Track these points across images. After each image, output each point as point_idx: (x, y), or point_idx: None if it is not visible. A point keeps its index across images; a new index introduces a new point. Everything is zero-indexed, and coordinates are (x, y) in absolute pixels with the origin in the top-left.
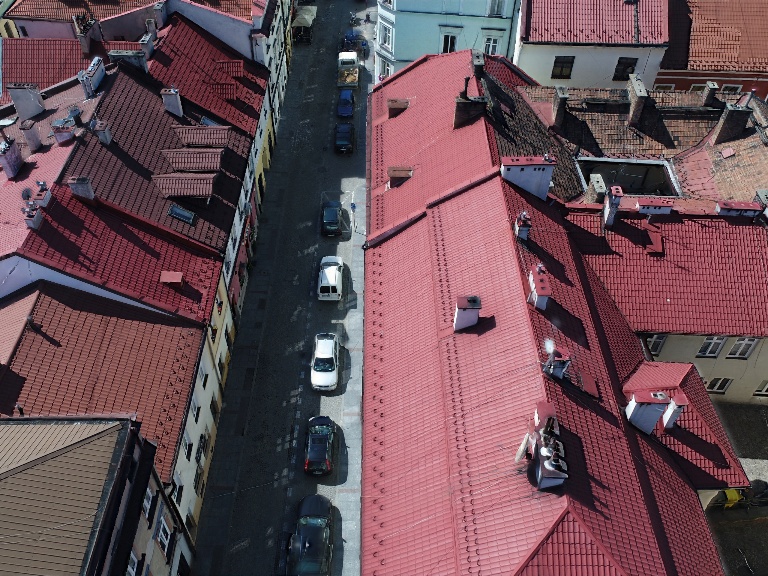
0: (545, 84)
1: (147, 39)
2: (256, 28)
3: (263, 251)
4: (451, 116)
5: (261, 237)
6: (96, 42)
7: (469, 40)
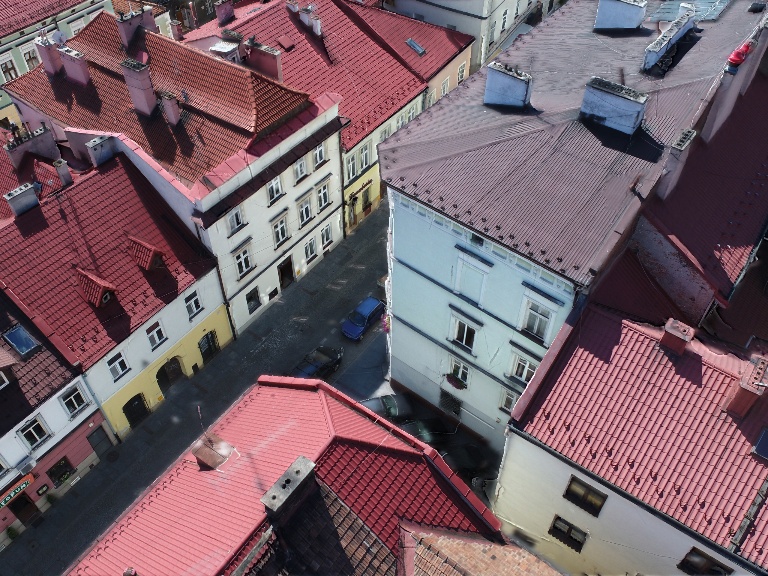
0: (553, 496)
1: (16, 193)
2: (199, 209)
3: (66, 508)
4: (174, 570)
5: (85, 482)
6: (30, 158)
7: (492, 345)
